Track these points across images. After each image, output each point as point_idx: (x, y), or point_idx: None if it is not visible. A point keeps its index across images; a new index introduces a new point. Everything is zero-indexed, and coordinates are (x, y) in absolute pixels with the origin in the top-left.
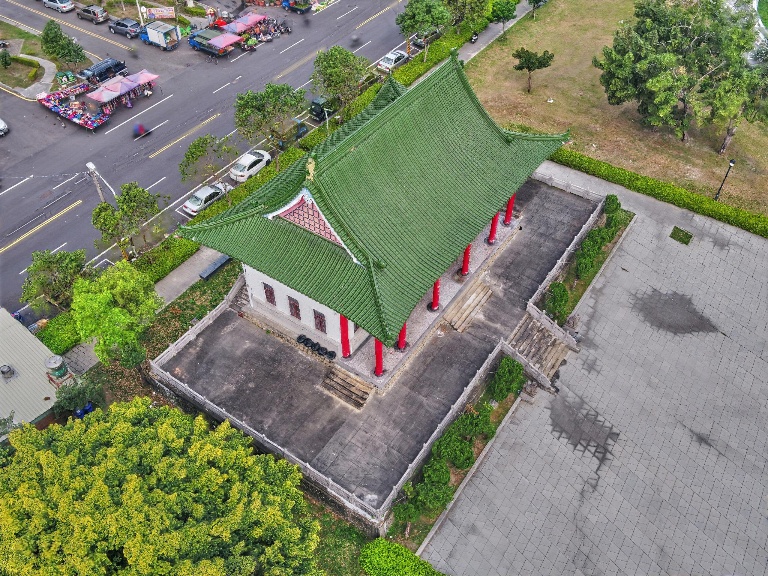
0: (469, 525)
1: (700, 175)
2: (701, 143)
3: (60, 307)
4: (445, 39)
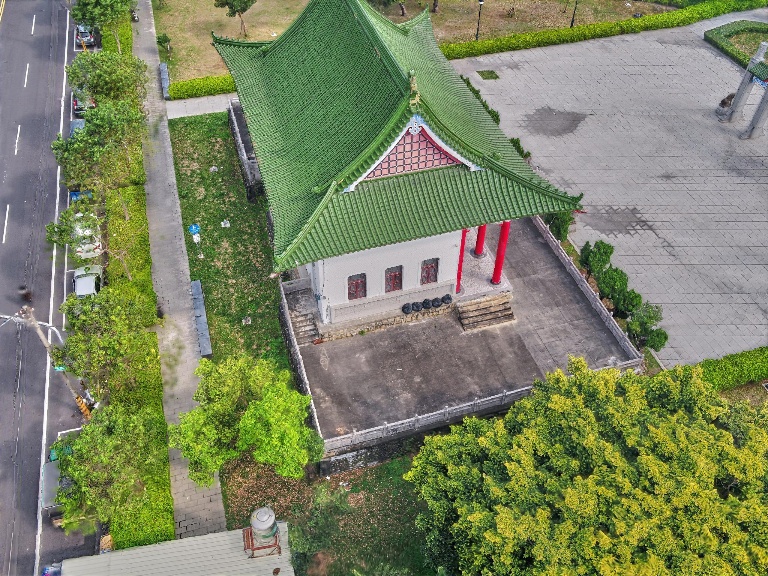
0: (659, 327)
1: (443, 32)
2: (415, 11)
3: (86, 518)
4: (110, 27)
